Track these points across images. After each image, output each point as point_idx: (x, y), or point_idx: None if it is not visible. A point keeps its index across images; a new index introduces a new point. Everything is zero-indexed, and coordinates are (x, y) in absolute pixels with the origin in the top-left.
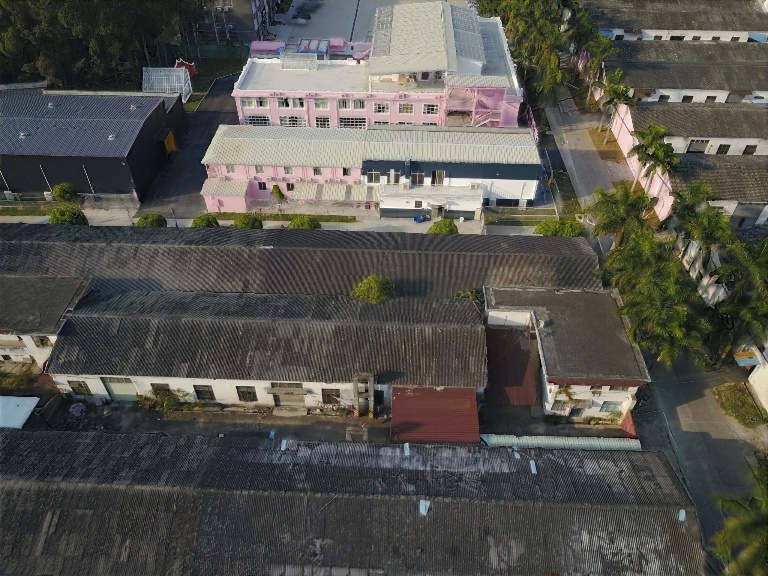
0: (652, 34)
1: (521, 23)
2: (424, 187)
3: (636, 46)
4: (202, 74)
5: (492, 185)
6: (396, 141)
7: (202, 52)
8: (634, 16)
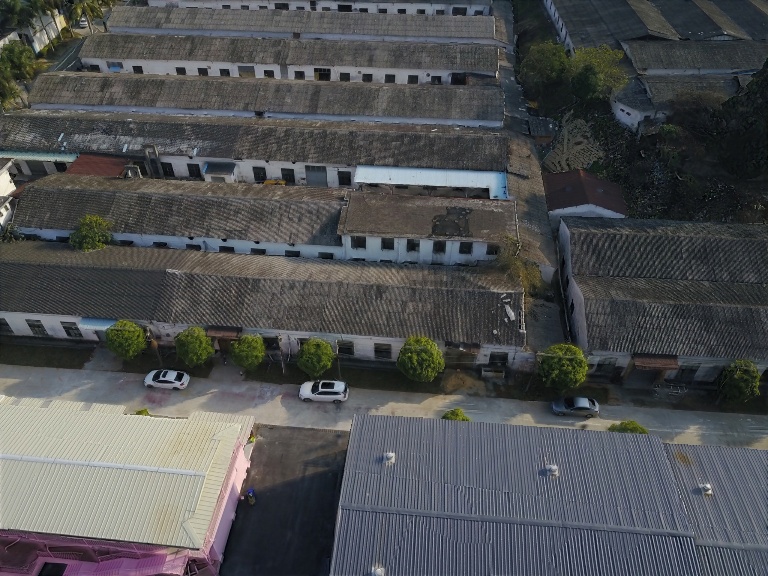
0: None
1: None
2: None
3: None
4: None
5: None
6: None
7: None
8: None
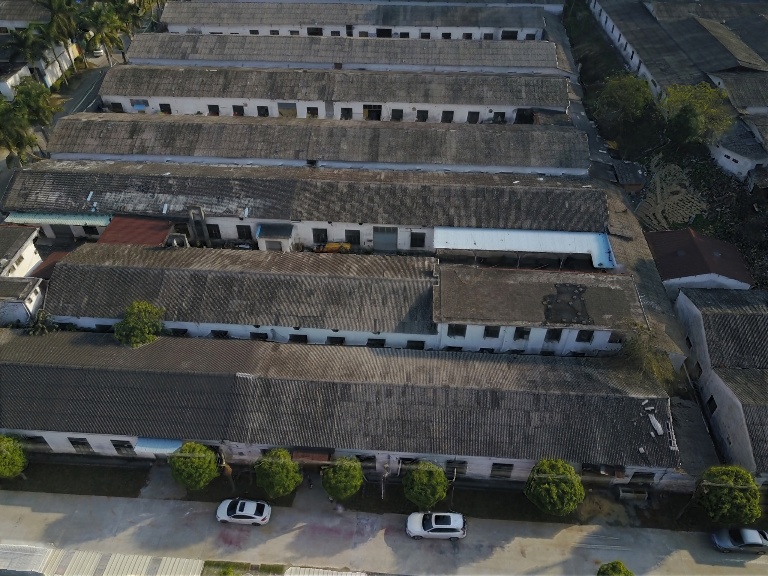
0: None
1: None
2: None
3: None
4: None
5: None
6: None
7: None
8: None
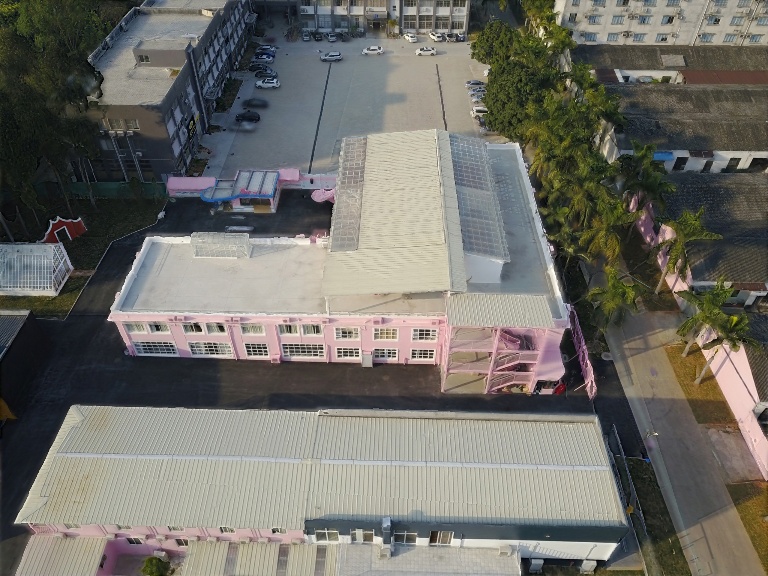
0: (727, 156)
1: (556, 175)
2: (417, 550)
3: (718, 192)
4: (94, 231)
5: (537, 546)
6: (367, 458)
7: (100, 191)
8: (701, 130)
